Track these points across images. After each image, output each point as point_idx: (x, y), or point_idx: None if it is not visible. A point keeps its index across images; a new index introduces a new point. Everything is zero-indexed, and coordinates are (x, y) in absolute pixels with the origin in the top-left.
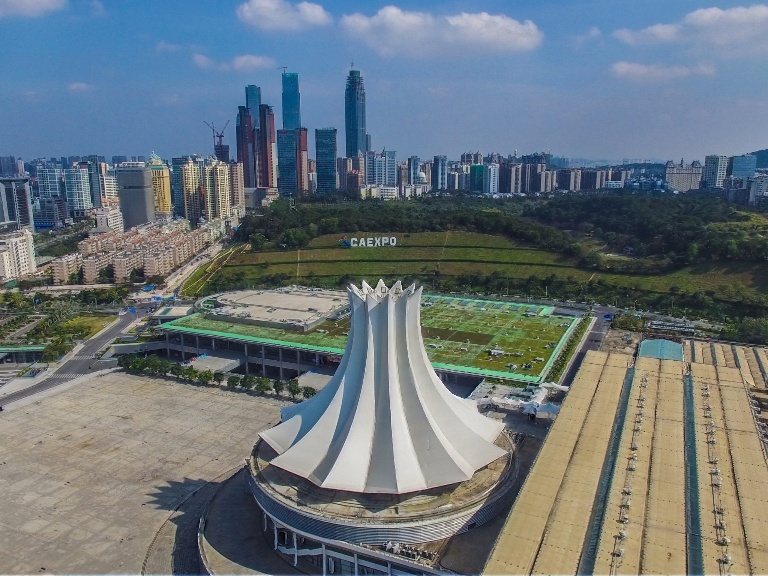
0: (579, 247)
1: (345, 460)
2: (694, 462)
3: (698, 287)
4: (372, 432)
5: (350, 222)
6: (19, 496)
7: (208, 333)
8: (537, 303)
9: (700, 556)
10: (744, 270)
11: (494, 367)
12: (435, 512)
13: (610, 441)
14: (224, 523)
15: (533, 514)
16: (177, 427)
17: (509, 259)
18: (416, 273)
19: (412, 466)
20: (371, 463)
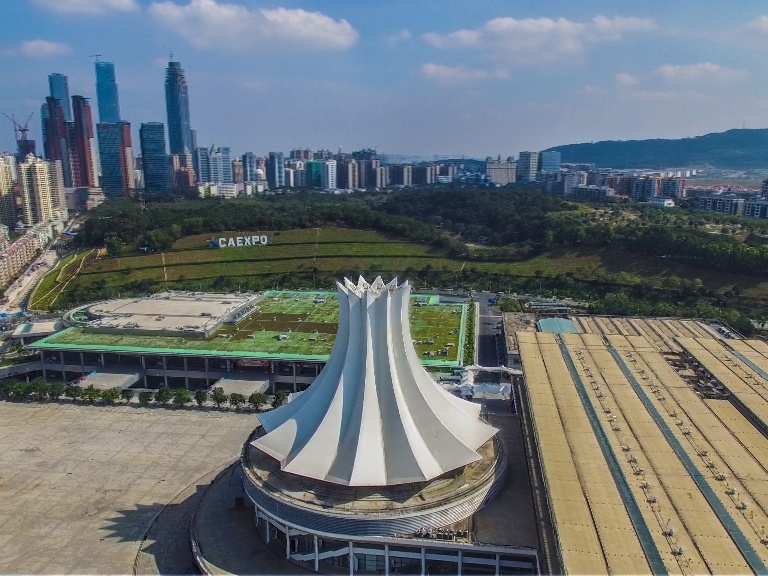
0: (448, 238)
1: (363, 456)
2: (660, 417)
3: (557, 270)
4: (380, 426)
5: (215, 222)
6: None
7: (96, 348)
8: (420, 293)
9: (712, 492)
10: (593, 253)
11: None
12: (458, 493)
13: (585, 408)
14: (219, 542)
15: (565, 479)
16: (100, 453)
17: (383, 252)
18: (294, 271)
19: (424, 454)
20: (386, 456)
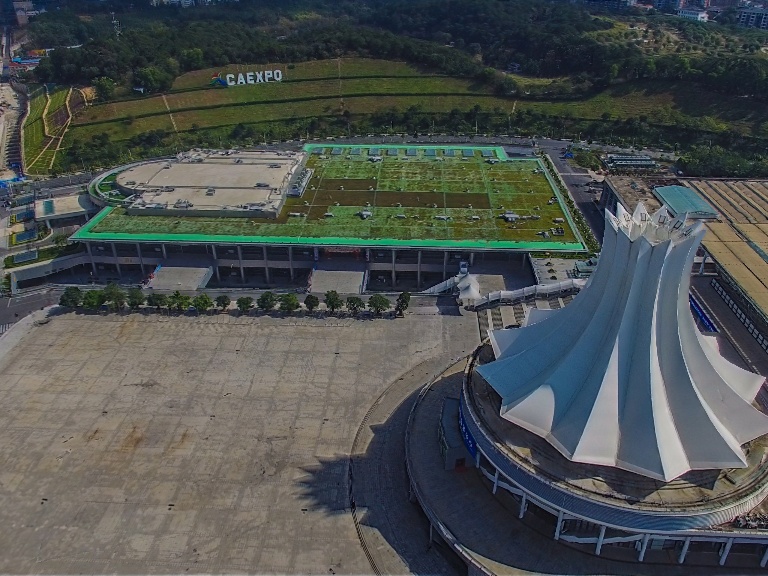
0: (494, 72)
1: (661, 439)
2: None
3: (624, 111)
4: (664, 395)
5: (217, 53)
6: (124, 547)
7: (157, 238)
8: (476, 142)
9: None
10: (663, 90)
11: (530, 238)
12: (763, 470)
13: None
14: (467, 521)
15: None
16: (231, 384)
17: (418, 89)
18: (322, 115)
19: None
20: (680, 432)
